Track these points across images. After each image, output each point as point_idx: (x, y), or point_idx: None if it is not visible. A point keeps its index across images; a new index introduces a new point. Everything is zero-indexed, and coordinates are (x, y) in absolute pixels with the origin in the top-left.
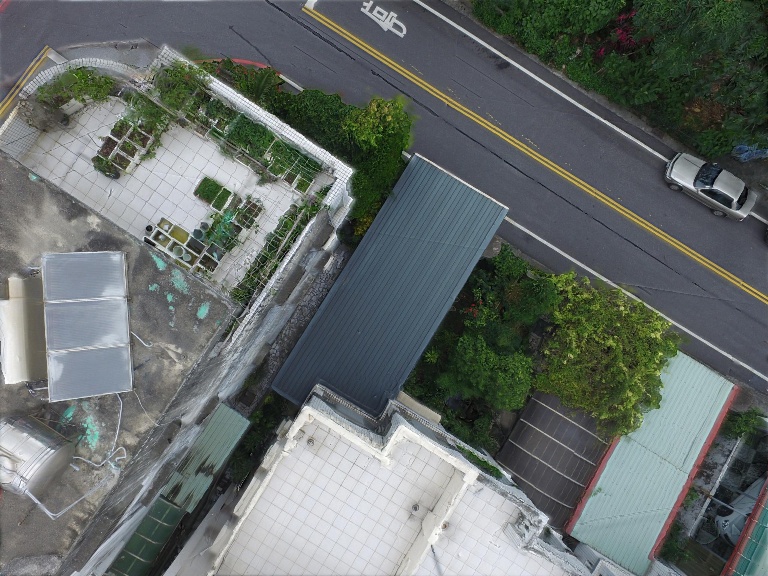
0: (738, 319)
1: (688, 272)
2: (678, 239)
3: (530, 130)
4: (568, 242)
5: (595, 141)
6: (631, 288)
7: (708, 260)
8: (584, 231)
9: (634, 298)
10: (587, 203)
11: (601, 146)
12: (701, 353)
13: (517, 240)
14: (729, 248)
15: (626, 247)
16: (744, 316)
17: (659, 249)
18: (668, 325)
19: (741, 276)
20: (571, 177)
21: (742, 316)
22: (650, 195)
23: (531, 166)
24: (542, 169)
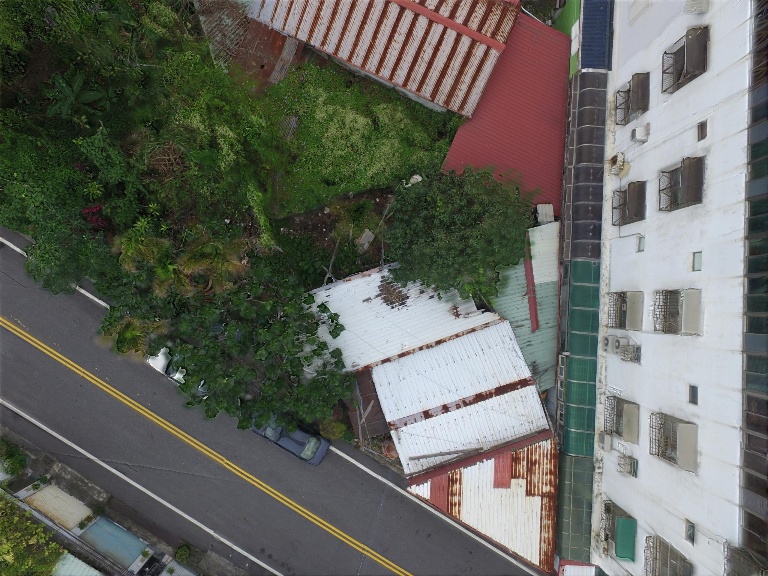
0: (221, 496)
1: (174, 450)
2: (165, 418)
3: (19, 311)
4: (55, 421)
5: (87, 321)
6: (118, 465)
7: (193, 438)
8: (71, 410)
9: (119, 475)
10: (74, 383)
11: (93, 326)
12: (185, 529)
13: (5, 418)
14: (215, 426)
15: (113, 425)
16: (227, 493)
17: (146, 427)
18: (28, 544)
19: (225, 454)
20: (59, 357)
21: (225, 493)
22: (140, 374)
23: (18, 346)
24: (30, 349)
